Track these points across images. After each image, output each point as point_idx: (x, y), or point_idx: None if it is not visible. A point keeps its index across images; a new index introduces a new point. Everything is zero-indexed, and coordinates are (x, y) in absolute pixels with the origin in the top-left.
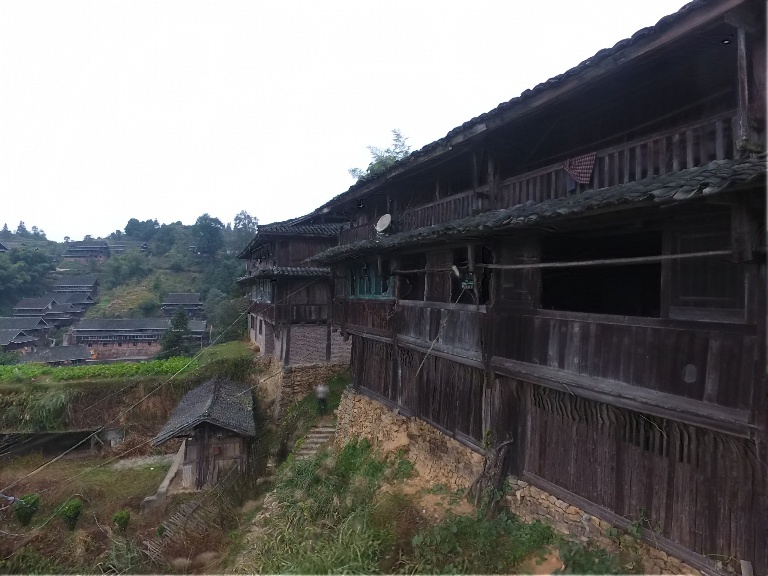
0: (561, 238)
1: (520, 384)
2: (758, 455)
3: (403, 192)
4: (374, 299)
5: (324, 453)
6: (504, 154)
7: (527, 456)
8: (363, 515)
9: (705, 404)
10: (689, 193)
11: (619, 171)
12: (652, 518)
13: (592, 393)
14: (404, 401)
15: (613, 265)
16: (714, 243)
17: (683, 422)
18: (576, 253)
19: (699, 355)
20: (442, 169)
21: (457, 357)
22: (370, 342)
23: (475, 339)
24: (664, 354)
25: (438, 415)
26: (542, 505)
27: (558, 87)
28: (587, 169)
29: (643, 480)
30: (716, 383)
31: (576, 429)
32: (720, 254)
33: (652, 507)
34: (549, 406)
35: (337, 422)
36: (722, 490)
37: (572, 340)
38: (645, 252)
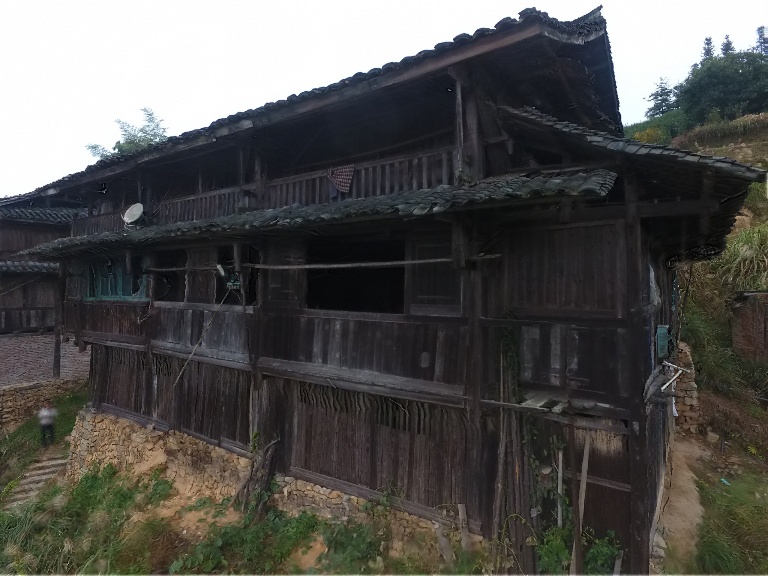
0: (325, 241)
1: (287, 382)
2: (469, 420)
3: (159, 180)
4: (121, 301)
5: (50, 492)
6: (271, 154)
7: (294, 452)
8: (106, 556)
9: (435, 384)
10: (424, 210)
11: (373, 184)
12: (398, 486)
13: (351, 384)
14: (160, 414)
15: (368, 268)
16: (441, 252)
17: (420, 401)
18: (338, 256)
19: (431, 344)
20: (205, 161)
21: (222, 361)
22: (116, 351)
23: (242, 341)
24: (407, 345)
25: (201, 424)
26: (308, 496)
27: (322, 99)
28: (347, 179)
29: (391, 455)
30: (442, 366)
31: (338, 419)
32: (445, 261)
33: (398, 477)
34: (314, 400)
35: (70, 451)
36: (446, 451)
37: (334, 337)
38: (393, 257)
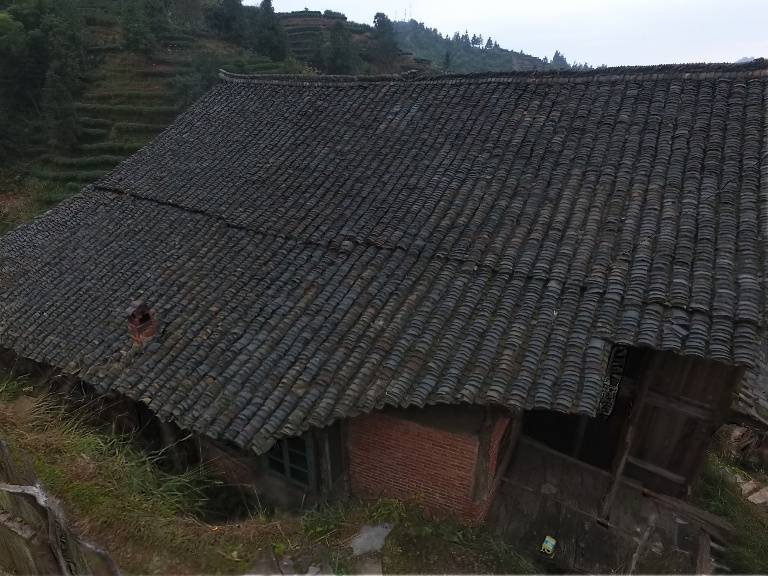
0: None
1: None
2: None
3: None
4: None
5: None
6: None
7: None
8: None
9: None
10: None
11: None
12: None
13: None
14: None
15: None
16: None
17: None
18: None
19: None
20: None
21: None
22: None
23: None
24: None
25: None
26: None
27: None
28: None
29: None
30: None
31: None
32: None
33: None
34: None
35: None
36: None
37: None
38: None
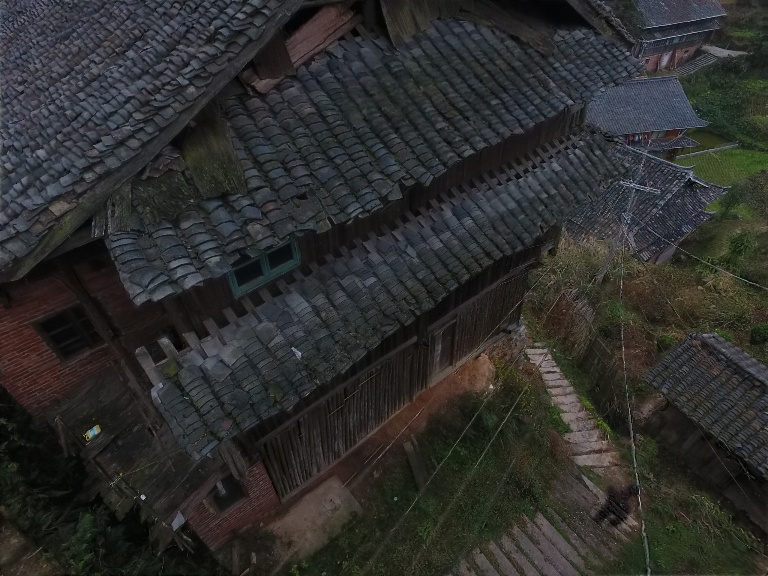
0: None
1: None
2: None
3: None
4: None
5: None
6: None
7: None
8: None
9: None
10: None
11: None
12: None
13: None
14: None
15: None
16: None
17: None
18: None
19: None
20: None
21: None
22: None
23: None
24: None
25: None
26: None
27: None
28: None
29: None
30: None
31: None
32: None
33: None
34: None
35: None
36: None
37: None
38: None
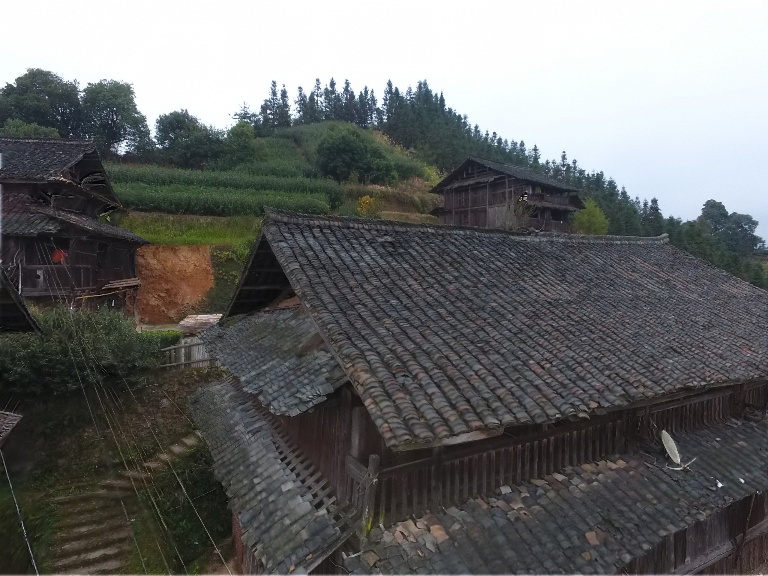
0: None
1: None
2: None
3: None
4: None
5: None
6: None
7: None
8: None
9: None
10: None
11: None
12: (751, 567)
13: None
14: None
15: None
16: None
17: None
18: None
19: None
20: None
21: None
22: None
23: (724, 533)
24: None
25: None
26: None
27: None
28: None
29: None
30: None
31: None
32: None
33: (750, 562)
34: None
35: None
36: None
37: None
38: None
